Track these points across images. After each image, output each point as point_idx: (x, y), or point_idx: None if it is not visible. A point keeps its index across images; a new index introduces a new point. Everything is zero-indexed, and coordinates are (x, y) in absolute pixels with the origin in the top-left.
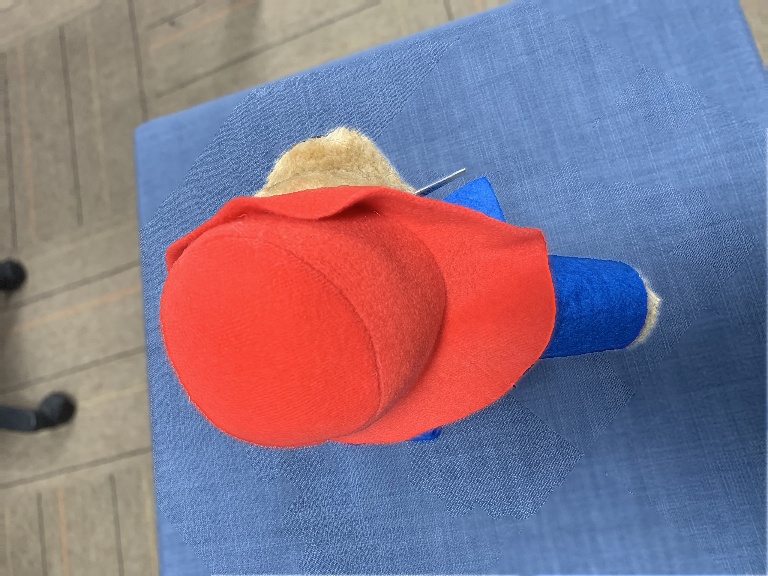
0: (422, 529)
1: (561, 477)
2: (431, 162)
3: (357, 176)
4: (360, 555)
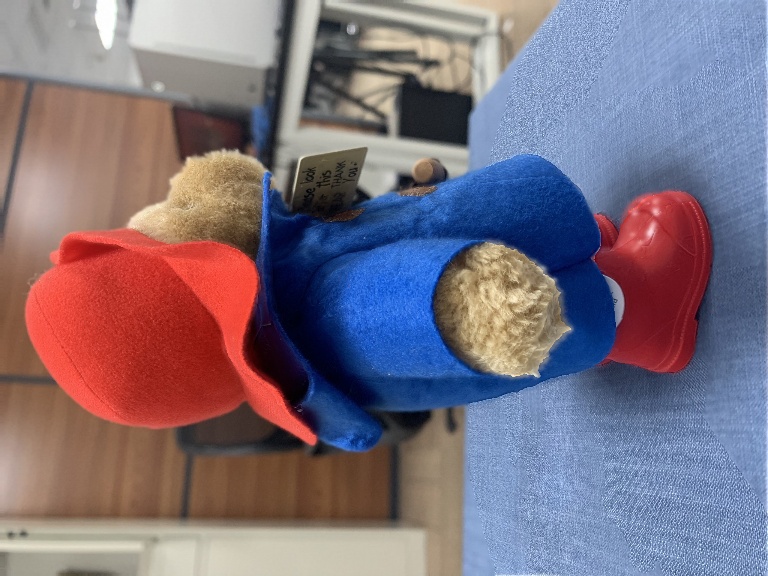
0: (607, 569)
1: (757, 571)
2: (648, 74)
3: None
4: (562, 571)
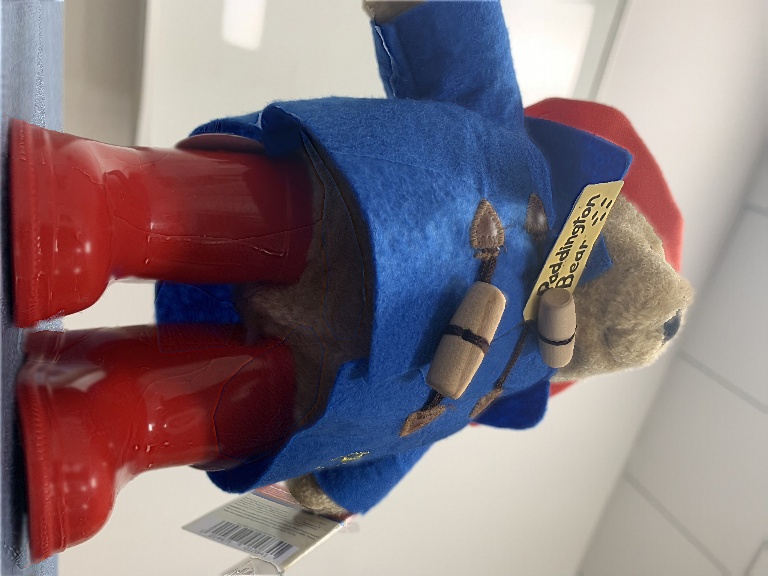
0: None
1: None
2: None
3: None
4: None
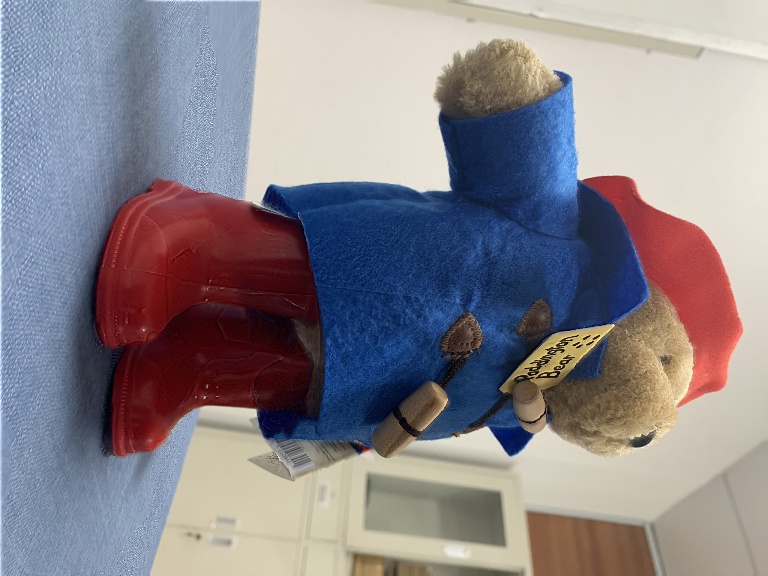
0: None
1: None
2: None
3: (681, 372)
4: None
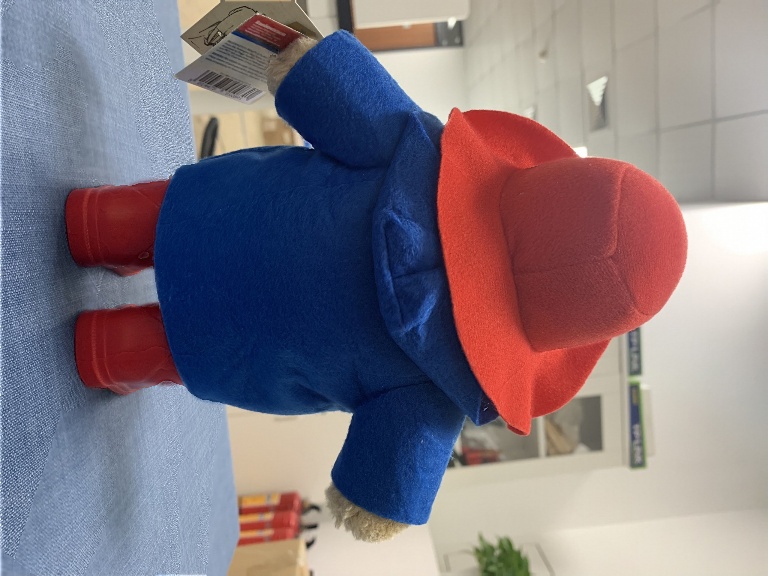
0: None
1: None
2: None
3: None
4: None
